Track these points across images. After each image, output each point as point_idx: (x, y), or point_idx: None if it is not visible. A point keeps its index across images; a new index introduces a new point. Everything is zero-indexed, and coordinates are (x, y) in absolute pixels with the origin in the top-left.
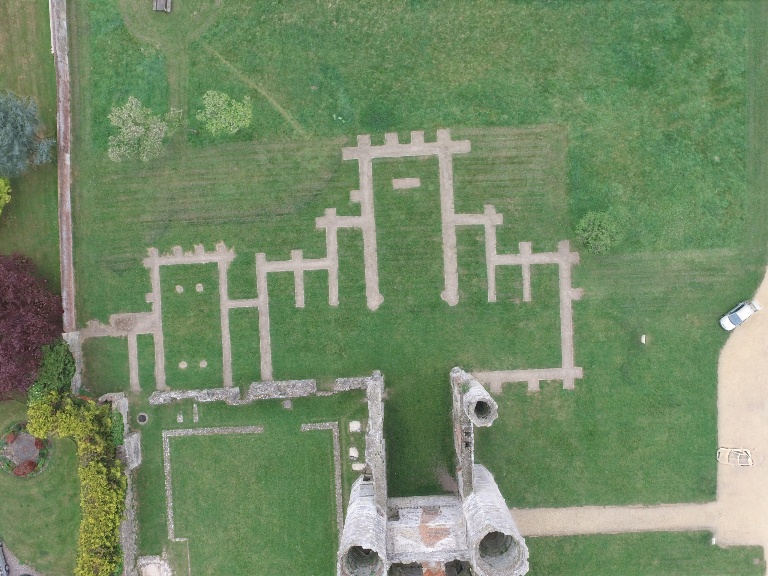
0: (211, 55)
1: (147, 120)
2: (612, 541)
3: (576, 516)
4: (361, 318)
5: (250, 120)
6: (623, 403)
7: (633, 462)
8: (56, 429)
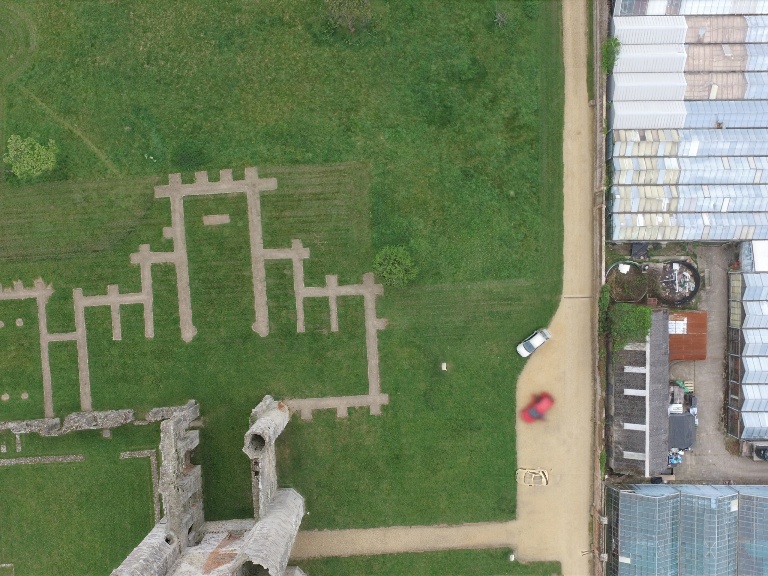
0: (27, 97)
1: None
2: (418, 559)
3: (384, 536)
4: (176, 350)
5: (53, 163)
6: (426, 428)
7: (437, 484)
8: None
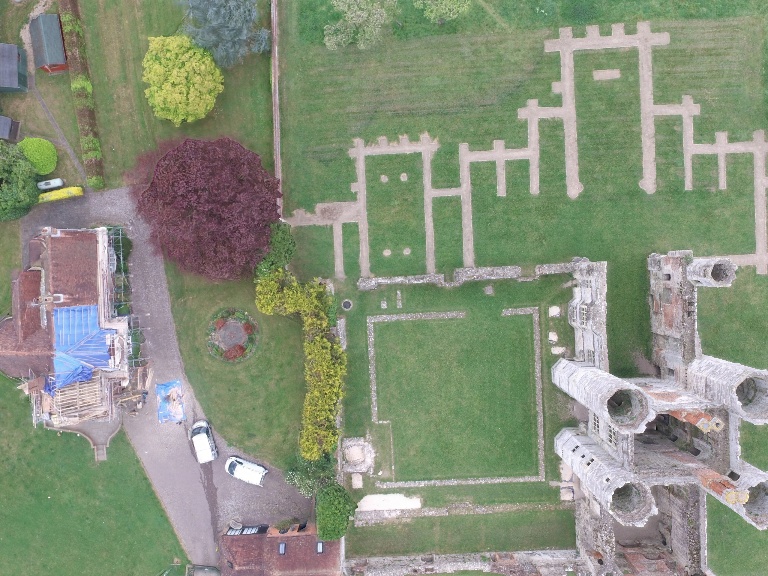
0: None
1: (368, 6)
2: None
3: None
4: (561, 206)
5: (468, 7)
6: None
7: None
8: (284, 304)
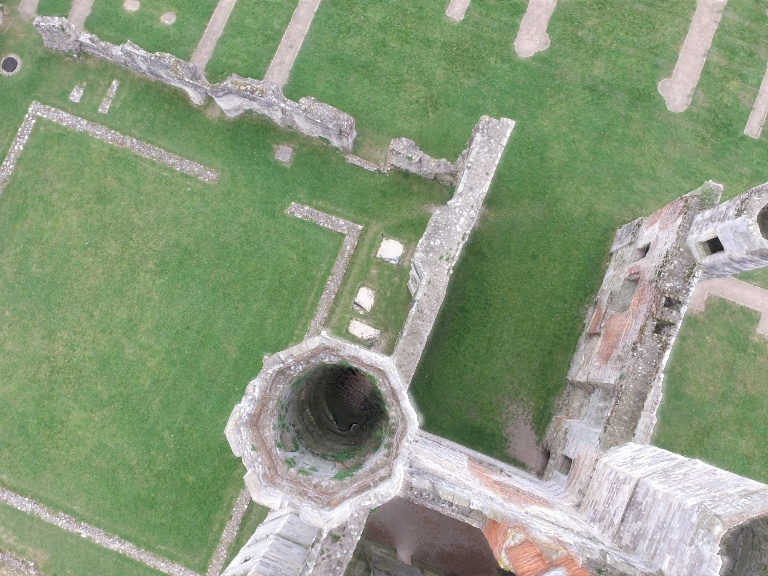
0: None
1: None
2: None
3: None
4: (492, 60)
5: None
6: None
7: None
8: None
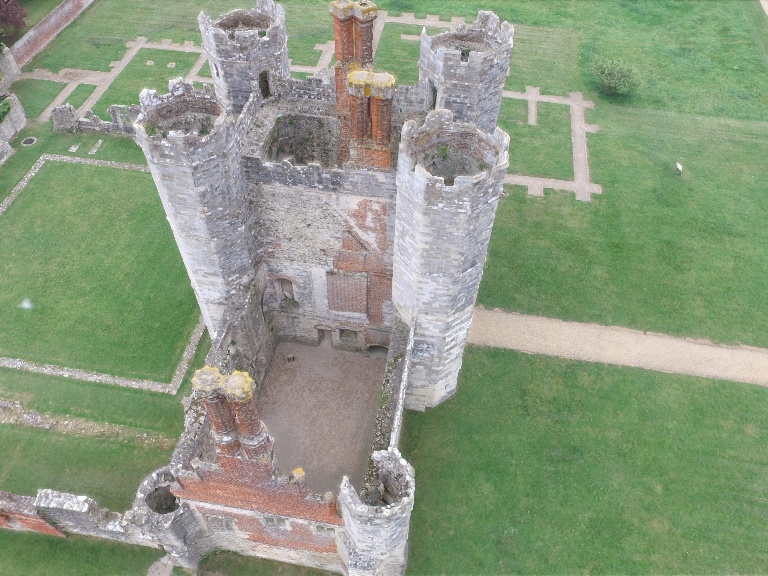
0: None
1: None
2: (663, 381)
3: (598, 337)
4: None
5: None
6: (660, 221)
7: (685, 284)
8: None
